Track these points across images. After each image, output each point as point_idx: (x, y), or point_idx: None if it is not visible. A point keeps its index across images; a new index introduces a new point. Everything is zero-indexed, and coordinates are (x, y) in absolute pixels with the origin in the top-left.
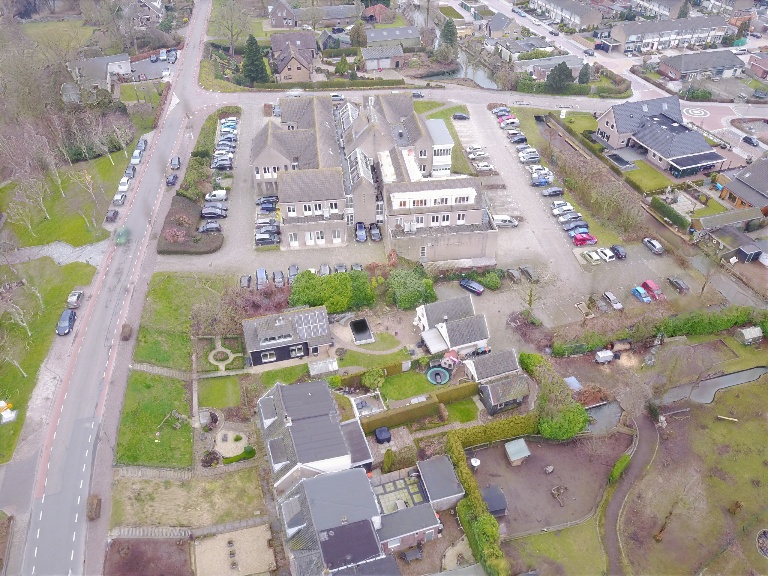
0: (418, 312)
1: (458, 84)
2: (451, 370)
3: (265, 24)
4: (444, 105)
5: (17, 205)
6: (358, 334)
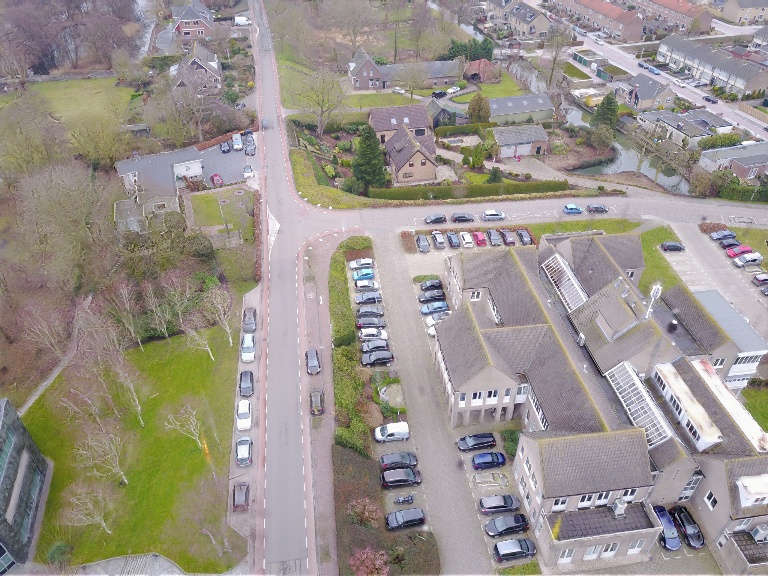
0: None
1: (639, 186)
2: None
3: (343, 84)
4: (640, 225)
5: (84, 496)
6: None
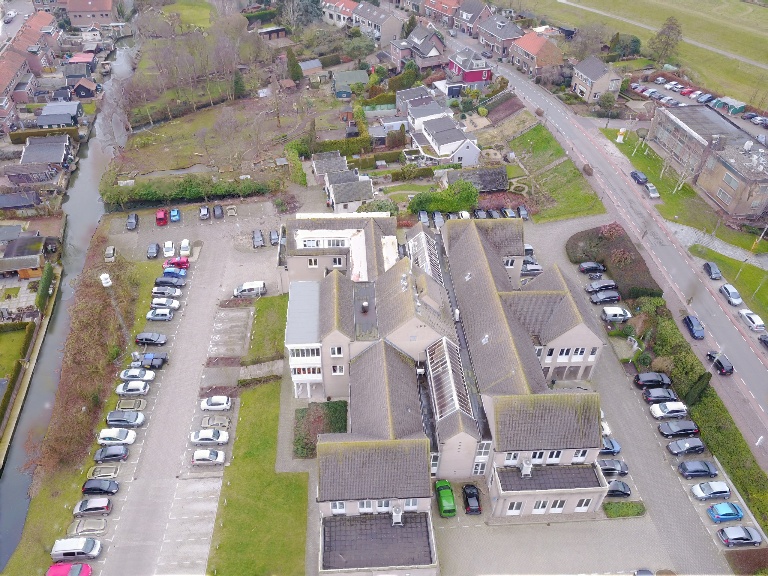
0: None
1: None
2: None
3: None
4: None
5: None
6: None
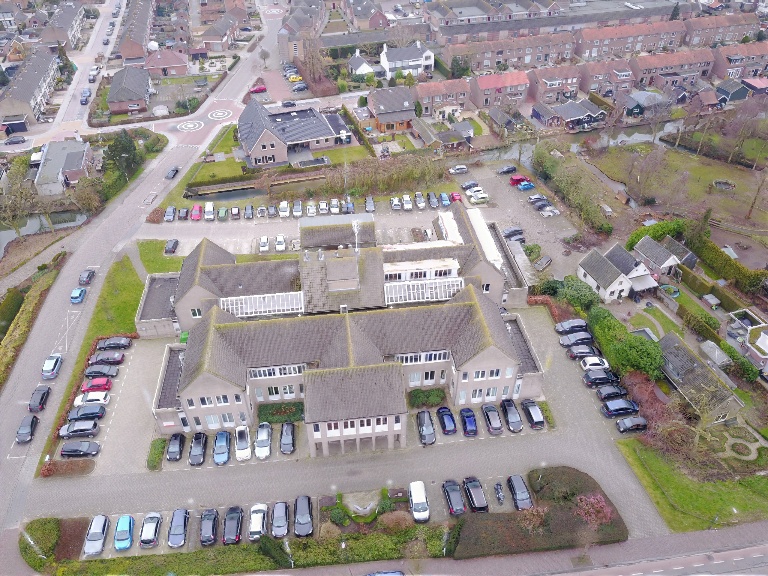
0: None
1: (56, 241)
2: None
3: None
4: (129, 256)
5: None
6: None
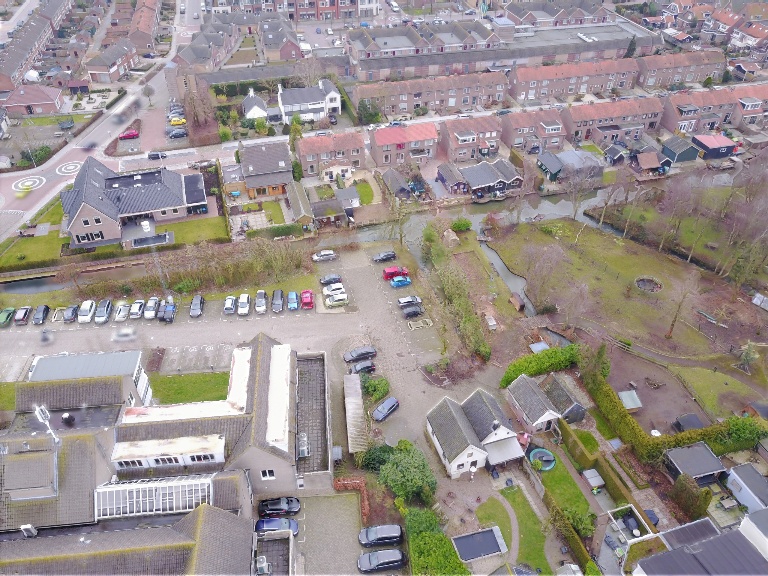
0: (457, 463)
1: None
2: (530, 446)
3: None
4: None
5: None
6: (481, 551)
